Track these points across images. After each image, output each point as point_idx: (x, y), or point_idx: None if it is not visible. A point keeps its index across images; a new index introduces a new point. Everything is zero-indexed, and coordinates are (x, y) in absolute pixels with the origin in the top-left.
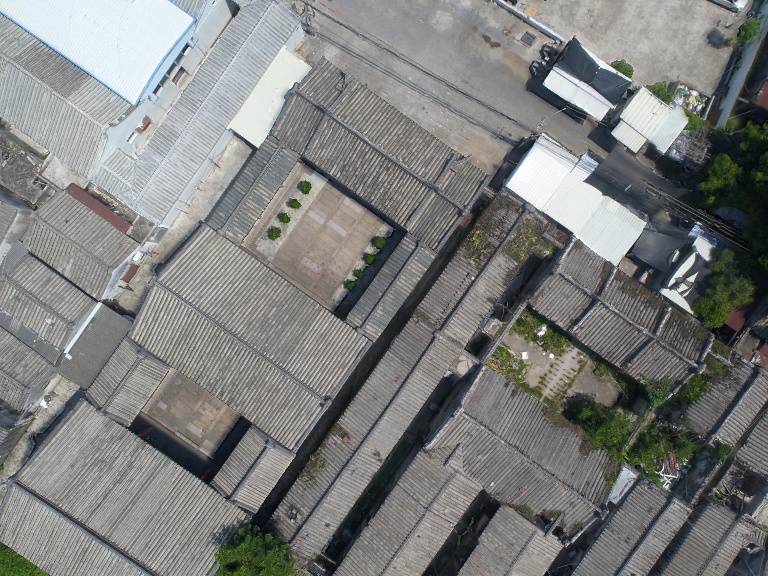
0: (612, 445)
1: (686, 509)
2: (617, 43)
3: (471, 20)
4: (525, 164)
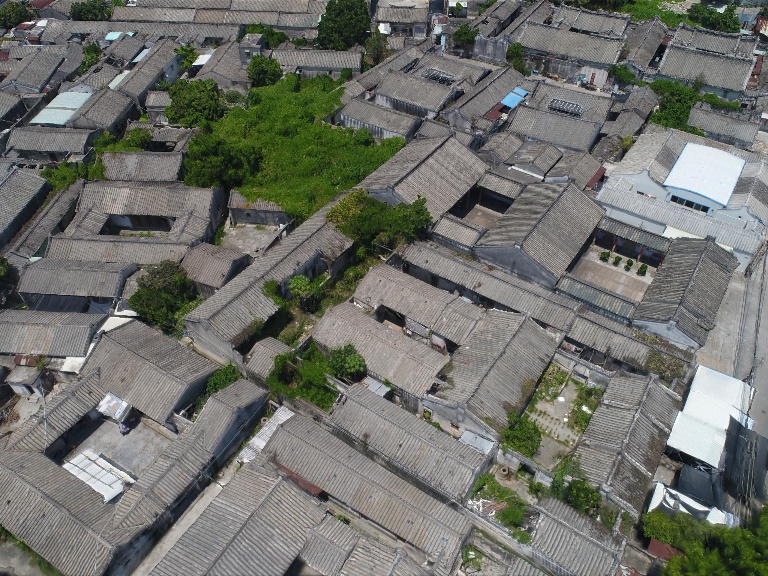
0: (510, 439)
1: (467, 487)
2: None
3: None
4: (723, 376)
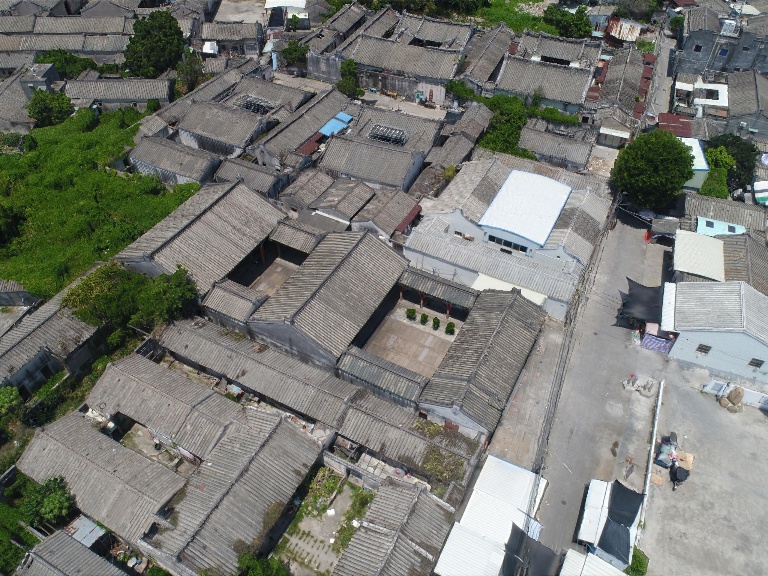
0: None
1: None
2: (667, 568)
3: (626, 431)
4: (513, 467)
